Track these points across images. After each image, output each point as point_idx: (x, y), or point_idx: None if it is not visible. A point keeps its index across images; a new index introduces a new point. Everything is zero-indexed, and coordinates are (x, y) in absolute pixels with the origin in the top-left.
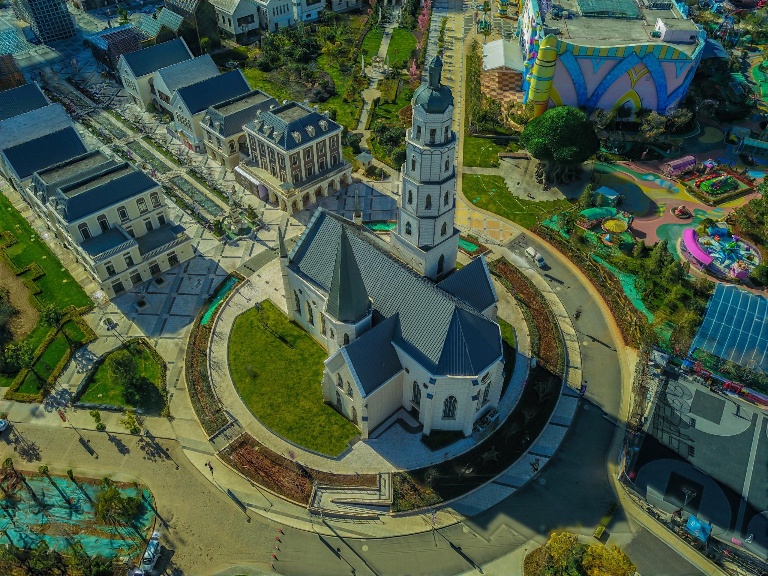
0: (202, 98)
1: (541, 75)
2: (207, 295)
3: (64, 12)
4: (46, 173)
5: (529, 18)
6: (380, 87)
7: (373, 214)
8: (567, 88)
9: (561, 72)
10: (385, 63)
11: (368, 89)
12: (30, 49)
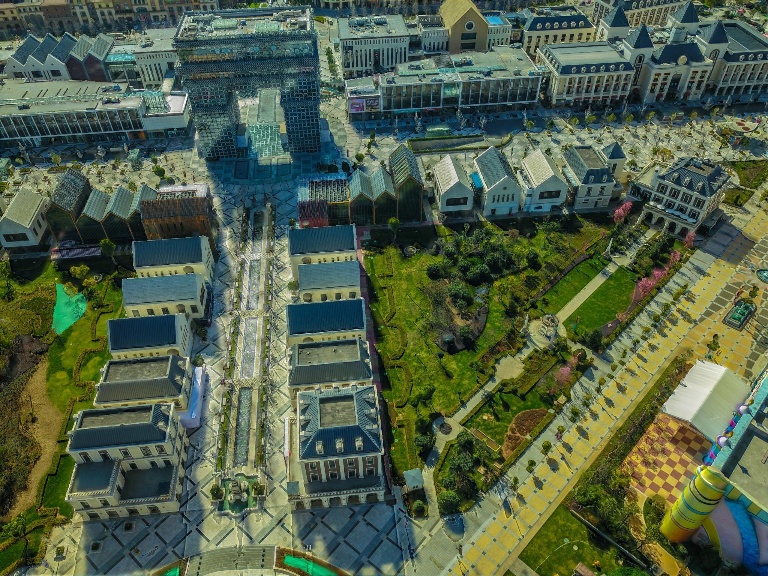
0: (309, 320)
1: (690, 503)
2: (147, 573)
3: (315, 131)
4: (117, 364)
5: (766, 373)
6: (527, 361)
7: (364, 567)
8: (731, 533)
9: (726, 514)
10: (565, 322)
11: (513, 357)
12: (276, 155)
